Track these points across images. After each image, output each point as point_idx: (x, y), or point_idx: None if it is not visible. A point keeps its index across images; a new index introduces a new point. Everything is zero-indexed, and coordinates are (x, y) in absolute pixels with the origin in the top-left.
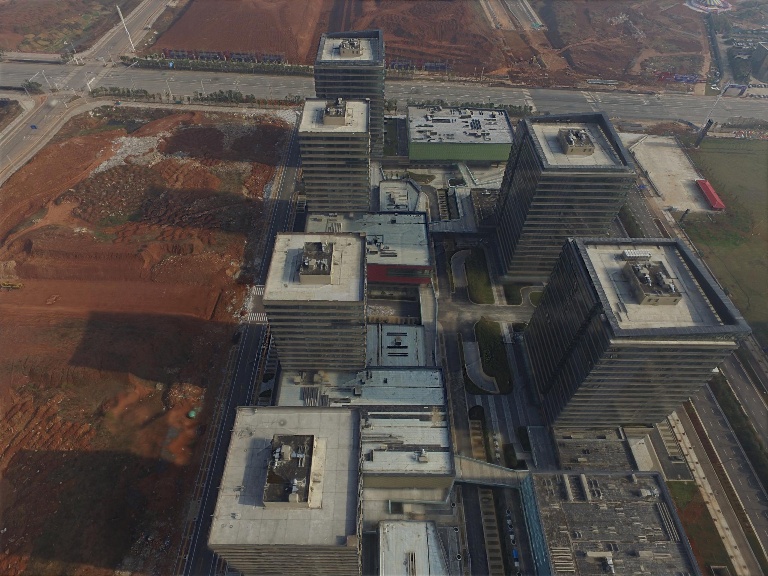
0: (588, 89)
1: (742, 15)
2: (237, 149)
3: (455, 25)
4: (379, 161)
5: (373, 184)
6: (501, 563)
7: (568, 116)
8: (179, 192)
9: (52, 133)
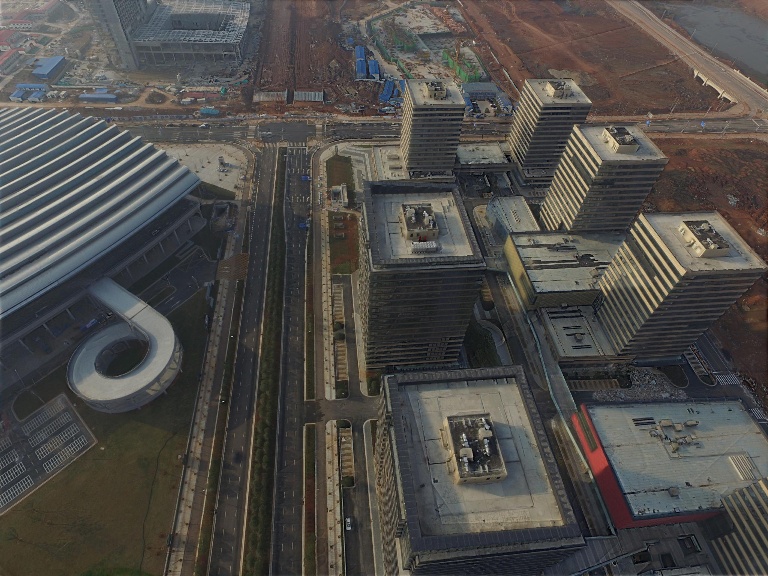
0: None
1: None
2: None
3: None
4: None
5: None
6: None
7: (491, 532)
8: None
9: None
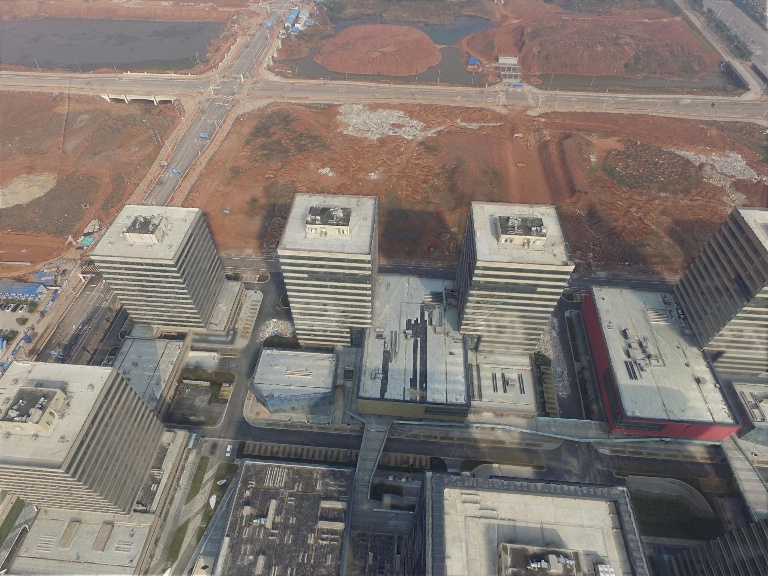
0: None
1: None
2: None
3: None
4: None
5: None
6: (298, 456)
7: None
8: (675, 205)
9: (716, 118)
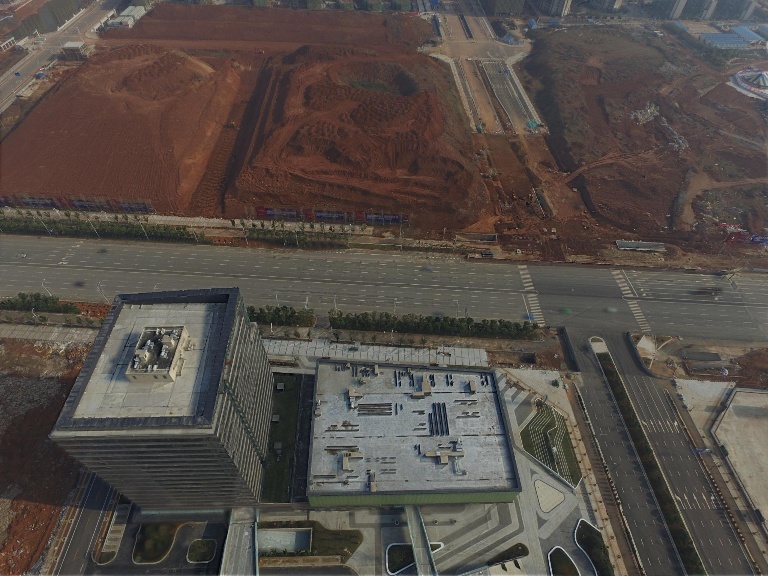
0: (621, 266)
1: None
2: (5, 452)
3: (416, 142)
4: (254, 507)
5: None
6: None
7: None
8: None
9: None
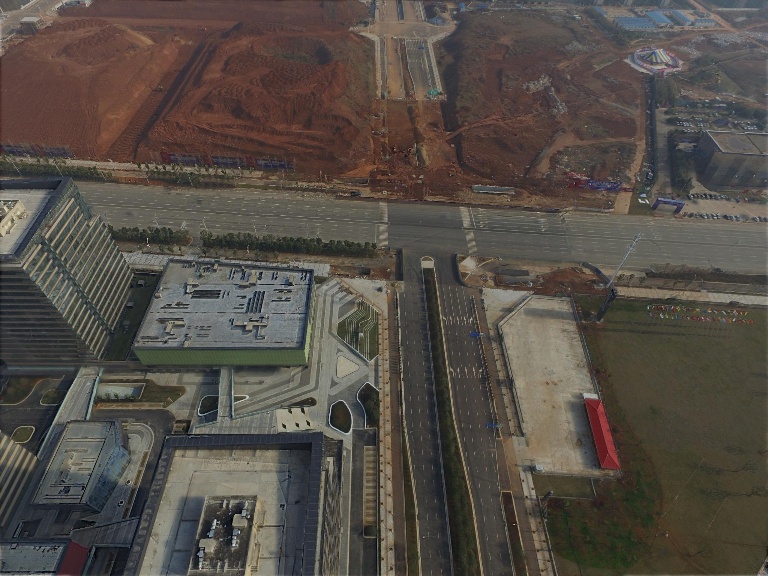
0: (469, 204)
1: (693, 78)
2: None
3: (313, 102)
4: (99, 365)
5: (65, 420)
6: None
7: (248, 444)
8: None
9: None
